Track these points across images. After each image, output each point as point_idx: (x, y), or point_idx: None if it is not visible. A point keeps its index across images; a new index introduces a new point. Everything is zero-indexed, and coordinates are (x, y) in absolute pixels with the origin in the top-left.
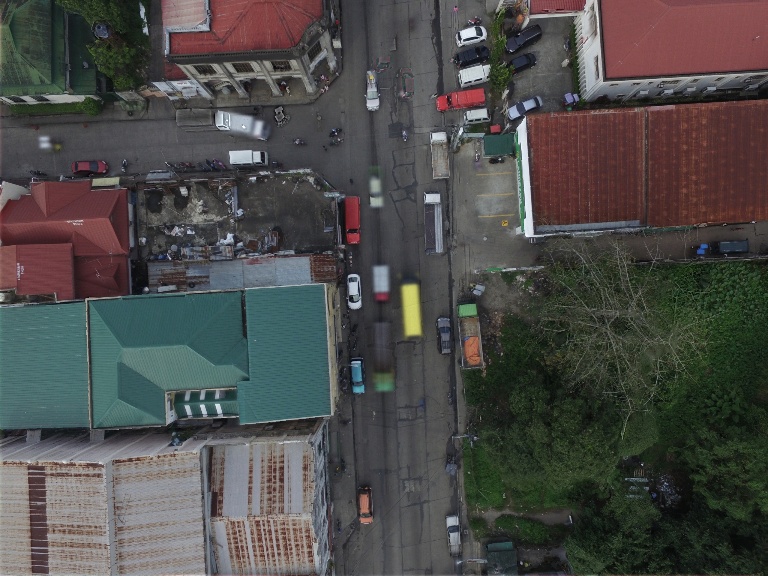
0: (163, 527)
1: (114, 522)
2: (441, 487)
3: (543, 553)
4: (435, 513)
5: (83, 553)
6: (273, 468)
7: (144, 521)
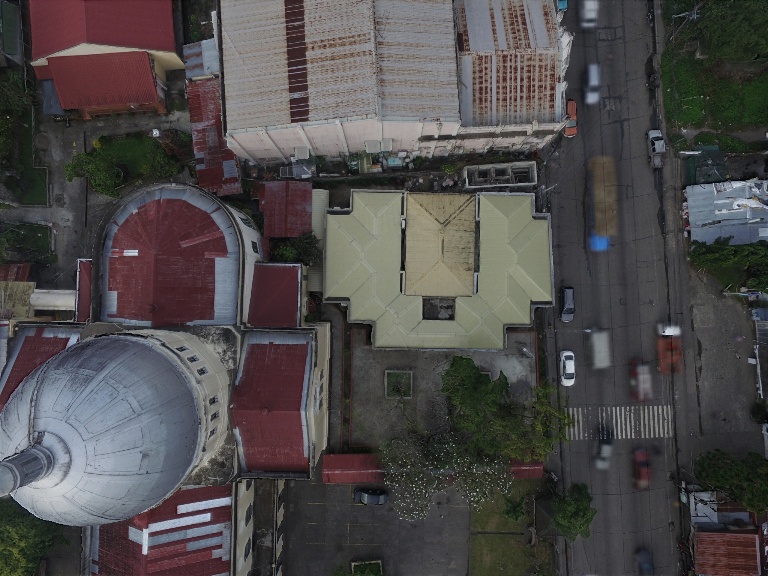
0: (419, 48)
1: (374, 36)
2: (640, 106)
3: (742, 168)
4: (635, 131)
5: (345, 64)
6: (514, 15)
7: (402, 39)
